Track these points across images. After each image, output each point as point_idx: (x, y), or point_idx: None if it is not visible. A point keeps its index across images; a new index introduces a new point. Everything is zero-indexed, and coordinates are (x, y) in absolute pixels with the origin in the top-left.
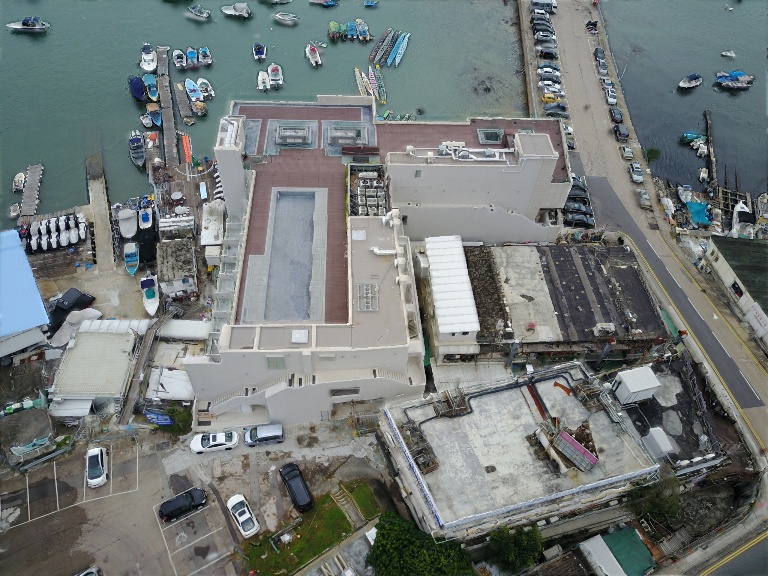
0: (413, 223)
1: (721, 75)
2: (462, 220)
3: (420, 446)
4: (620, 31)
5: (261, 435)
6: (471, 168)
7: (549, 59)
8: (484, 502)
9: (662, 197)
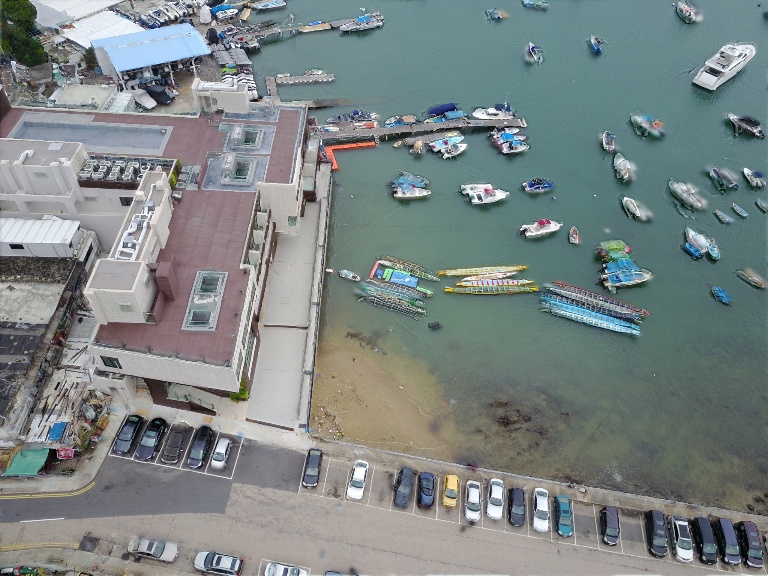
0: None
1: None
2: None
3: None
4: None
5: None
6: None
7: (601, 527)
8: None
9: None
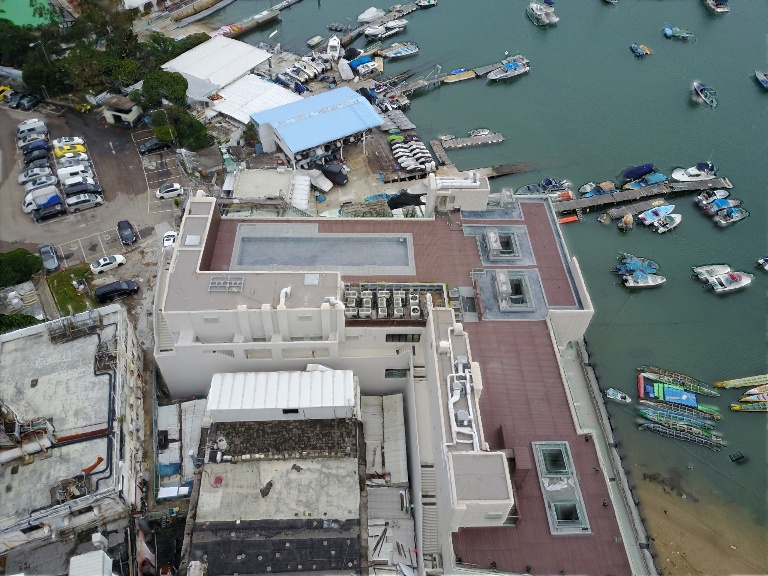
0: None
1: None
2: None
3: (69, 324)
4: None
5: None
6: None
7: None
8: (8, 375)
9: None
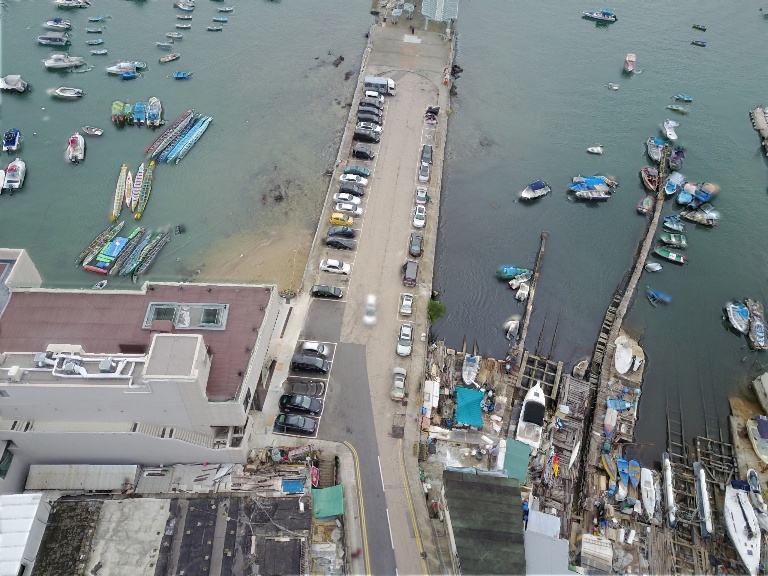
0: (26, 446)
1: (577, 180)
2: (94, 443)
3: None
4: (473, 117)
5: None
6: (76, 389)
7: (363, 159)
8: None
9: (433, 376)
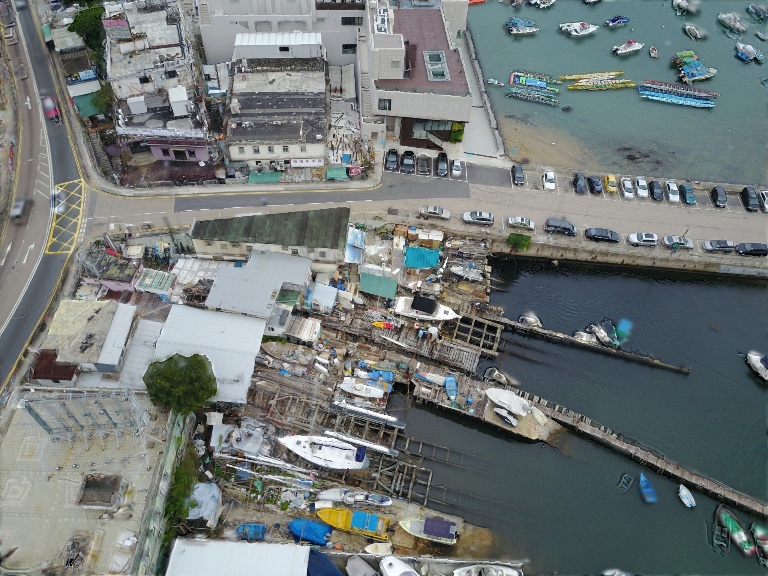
0: None
1: None
2: None
3: (148, 2)
4: None
5: (196, 0)
6: None
7: (713, 200)
8: None
9: (450, 240)
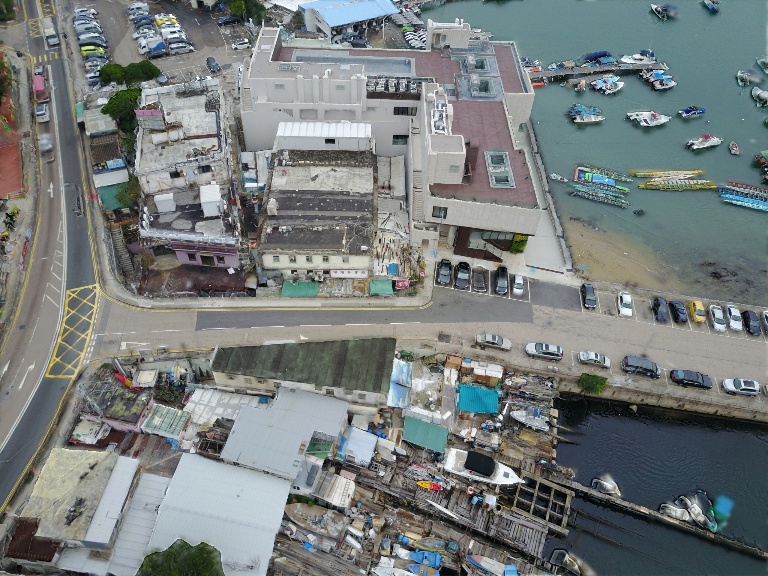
0: None
1: None
2: None
3: (188, 86)
4: None
5: None
6: None
7: None
8: None
9: (511, 377)
